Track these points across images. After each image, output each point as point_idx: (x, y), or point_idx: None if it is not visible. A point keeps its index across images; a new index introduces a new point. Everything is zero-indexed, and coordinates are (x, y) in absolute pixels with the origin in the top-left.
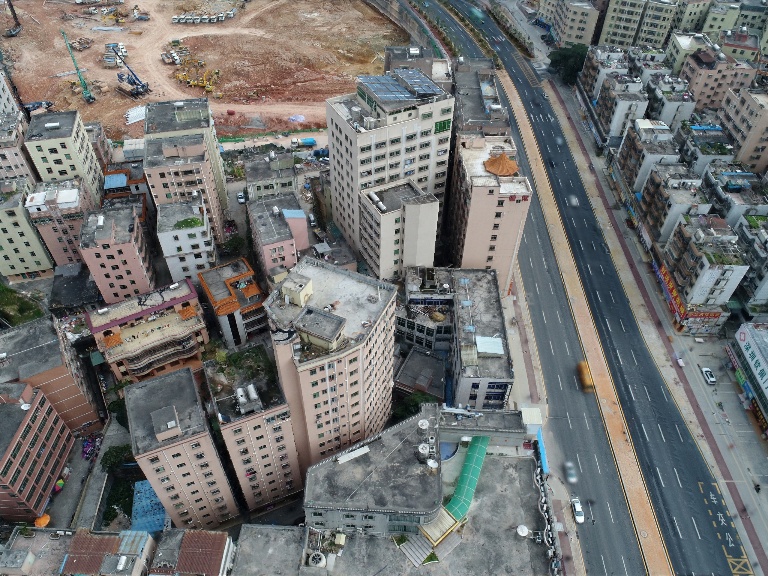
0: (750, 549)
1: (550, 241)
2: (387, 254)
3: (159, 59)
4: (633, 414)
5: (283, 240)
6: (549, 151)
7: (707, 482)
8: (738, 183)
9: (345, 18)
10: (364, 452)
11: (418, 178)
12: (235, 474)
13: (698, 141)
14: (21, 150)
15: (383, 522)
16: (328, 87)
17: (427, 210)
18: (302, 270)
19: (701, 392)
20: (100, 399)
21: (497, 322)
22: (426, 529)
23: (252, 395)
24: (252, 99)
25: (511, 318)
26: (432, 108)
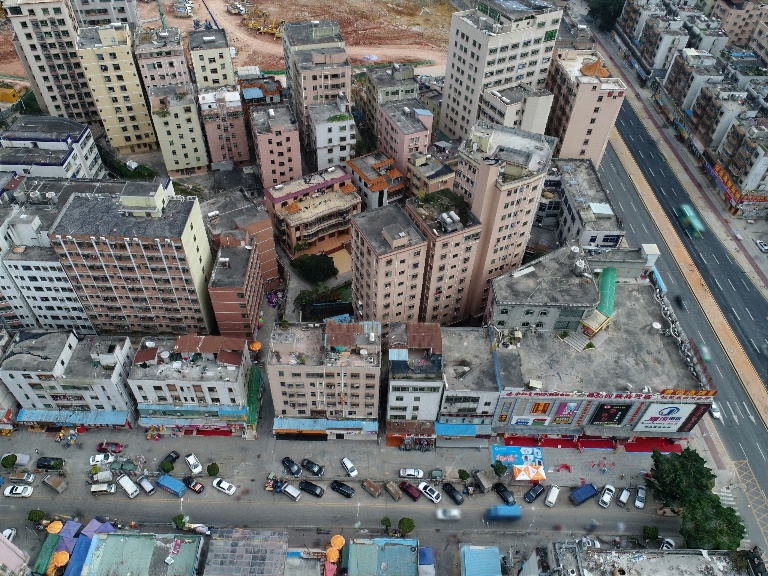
0: None
1: (614, 152)
2: None
3: (224, 10)
4: (707, 273)
5: (420, 131)
6: None
7: None
8: None
9: None
10: (531, 270)
11: (525, 83)
12: None
13: (738, 65)
14: (185, 59)
15: (553, 318)
16: (387, 34)
17: (543, 102)
18: None
19: (758, 257)
20: None
21: (601, 195)
22: (587, 322)
23: (456, 217)
24: None
25: None
26: (546, 18)
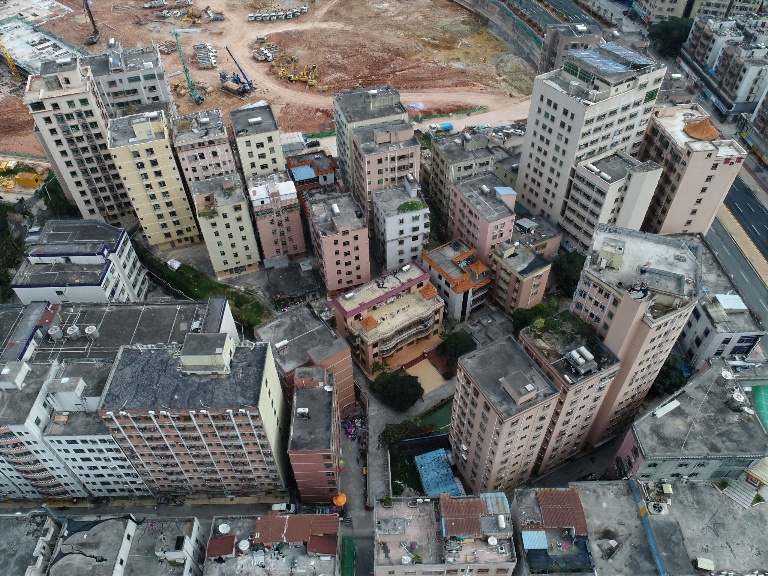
0: None
1: None
2: None
3: (249, 57)
4: None
5: (506, 216)
6: None
7: None
8: None
9: (417, 6)
10: (676, 405)
11: (620, 149)
12: None
13: None
14: (229, 146)
15: (712, 469)
16: (428, 74)
17: (651, 177)
18: (597, 236)
19: None
20: None
21: (724, 281)
22: (754, 472)
23: (589, 356)
24: None
25: None
26: (648, 78)
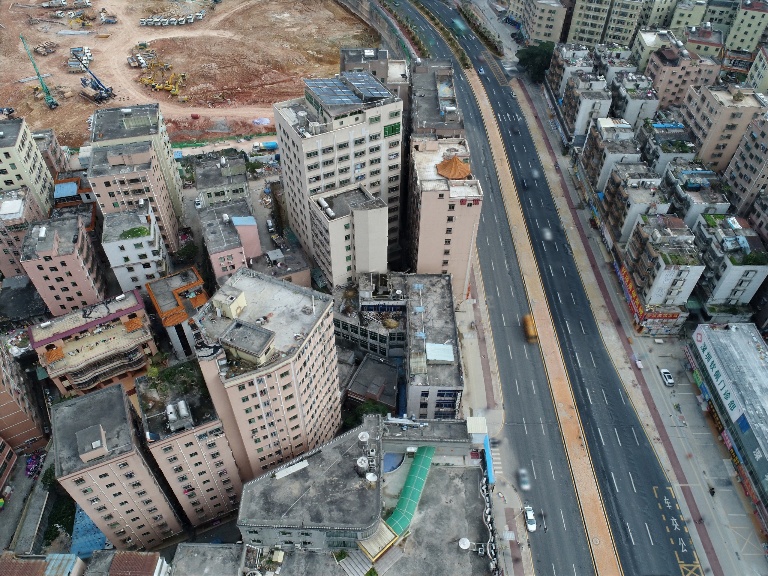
0: (703, 554)
1: (513, 243)
2: (339, 260)
3: (125, 63)
4: (590, 418)
5: (231, 248)
6: (515, 151)
7: (662, 486)
8: (697, 182)
9: (316, 18)
10: (303, 466)
11: (370, 182)
12: None
13: (659, 139)
14: None
15: (321, 538)
16: (295, 89)
17: (376, 216)
18: (237, 281)
19: (659, 394)
20: (46, 414)
21: (449, 328)
22: (364, 544)
23: (182, 412)
24: (218, 102)
25: (470, 322)
26: (379, 112)
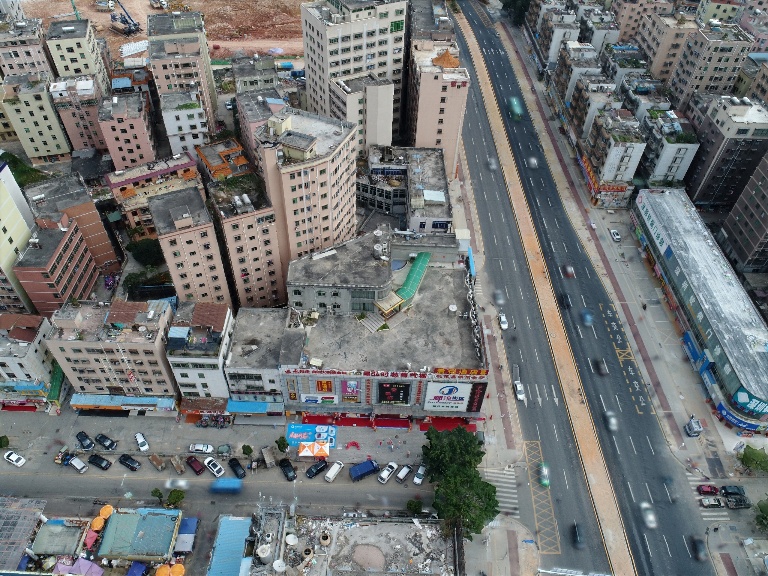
0: (634, 344)
1: (494, 143)
2: None
3: (148, 5)
4: (552, 261)
5: None
6: (498, 77)
7: (606, 303)
8: (645, 86)
9: None
10: (332, 253)
11: (378, 73)
12: (232, 281)
13: (617, 58)
14: (43, 49)
15: (347, 299)
16: None
17: (384, 92)
18: None
19: (608, 246)
20: (117, 249)
21: (442, 183)
22: (379, 303)
23: (246, 200)
24: (235, 37)
25: (458, 197)
26: (388, 9)
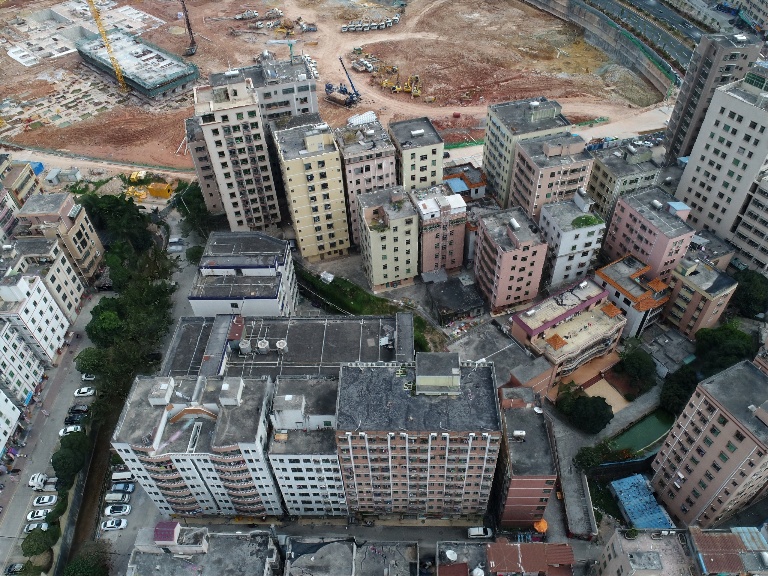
0: None
1: None
2: None
3: (348, 68)
4: None
5: (686, 232)
6: None
7: None
8: None
9: (509, 16)
10: None
11: None
12: None
13: None
14: None
15: None
16: (533, 84)
17: None
18: None
19: None
20: None
21: None
22: None
23: None
24: (465, 101)
25: None
26: None
